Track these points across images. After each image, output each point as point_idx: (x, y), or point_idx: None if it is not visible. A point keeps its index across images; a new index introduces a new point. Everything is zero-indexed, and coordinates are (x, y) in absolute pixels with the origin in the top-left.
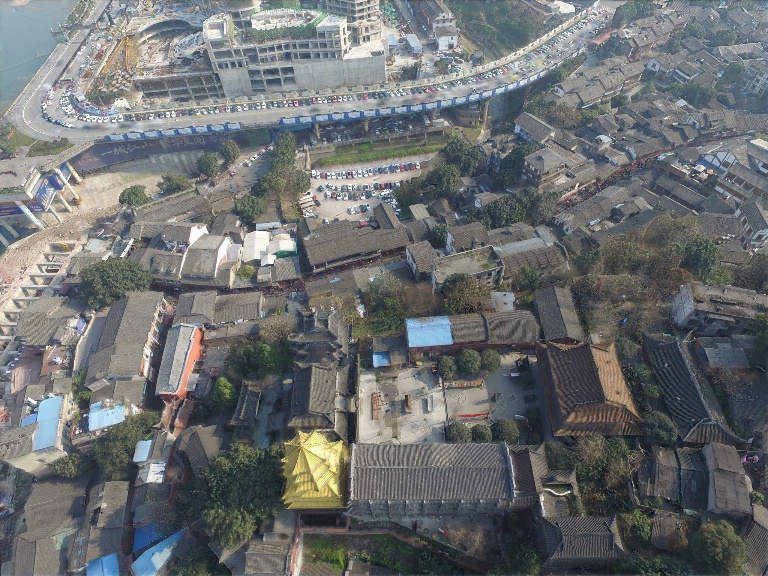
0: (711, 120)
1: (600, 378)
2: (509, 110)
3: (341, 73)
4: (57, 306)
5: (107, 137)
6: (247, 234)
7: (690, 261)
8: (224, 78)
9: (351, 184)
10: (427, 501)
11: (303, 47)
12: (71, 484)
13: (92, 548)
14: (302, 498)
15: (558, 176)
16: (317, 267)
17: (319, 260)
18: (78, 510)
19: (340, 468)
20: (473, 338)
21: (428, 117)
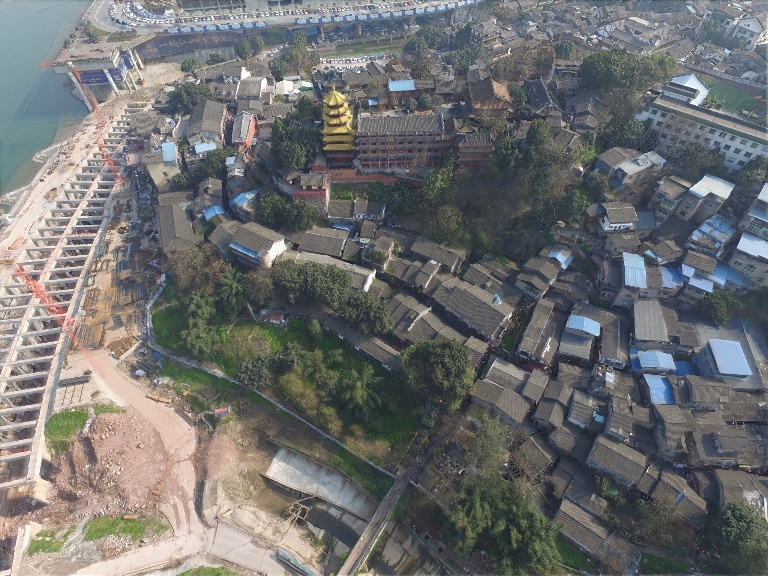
0: (608, 11)
1: (494, 88)
2: None
3: None
4: (154, 114)
5: (166, 30)
6: (278, 82)
7: (558, 50)
8: None
9: (349, 66)
10: (398, 133)
11: None
12: (183, 191)
13: (207, 201)
14: (333, 133)
15: (495, 41)
16: None
17: None
18: None
19: (352, 123)
20: (427, 87)
21: (407, 25)
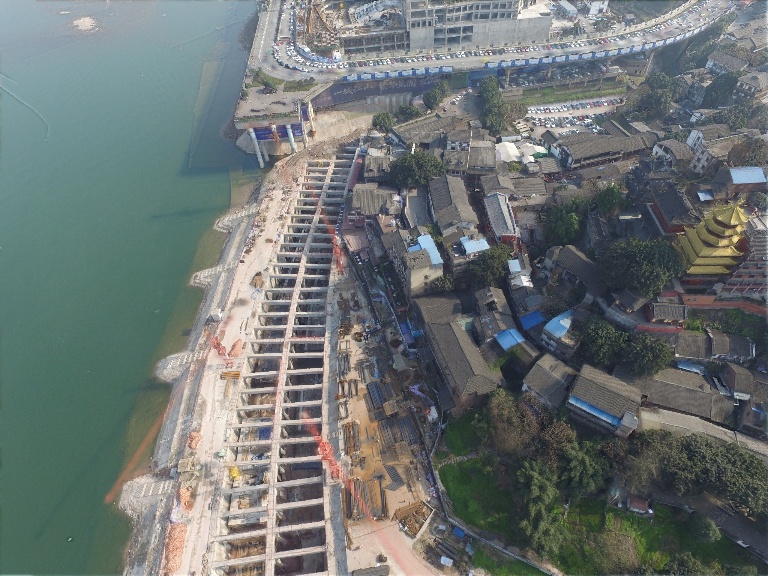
0: None
1: None
2: (664, 63)
3: (512, 32)
4: None
5: (345, 77)
6: (497, 144)
7: None
8: (413, 36)
9: None
10: None
11: (484, 8)
12: (444, 298)
13: (500, 323)
14: (712, 256)
15: (765, 95)
16: (574, 163)
17: (580, 156)
18: (459, 312)
19: None
20: None
21: (602, 65)
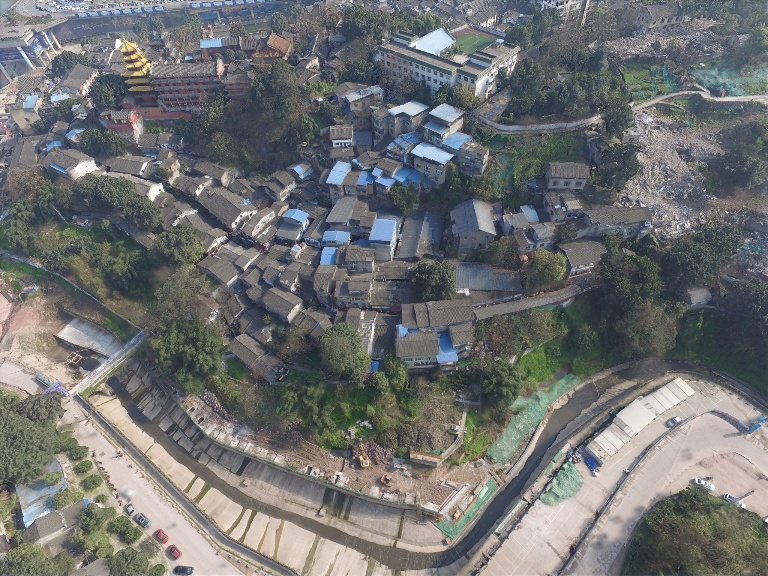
0: None
1: (272, 41)
2: None
3: None
4: (39, 77)
5: (76, 15)
6: None
7: (347, 13)
8: None
9: None
10: (182, 75)
11: None
12: (43, 134)
13: (49, 137)
14: (131, 76)
15: None
16: None
17: None
18: None
19: None
20: (232, 44)
21: None
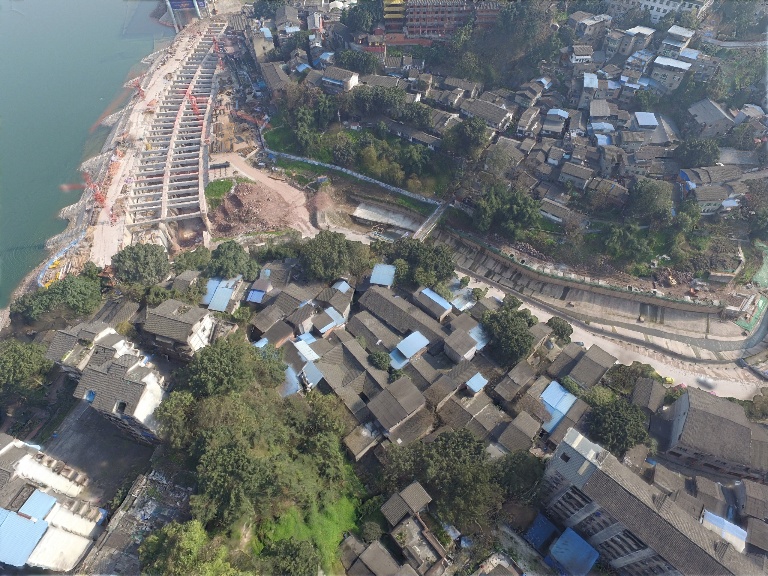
0: None
1: None
2: None
3: None
4: (244, 18)
5: None
6: (331, 3)
7: None
8: None
9: None
10: (435, 4)
11: None
12: None
13: (299, 60)
14: (391, 4)
15: None
16: None
17: None
18: None
19: None
20: None
21: None
